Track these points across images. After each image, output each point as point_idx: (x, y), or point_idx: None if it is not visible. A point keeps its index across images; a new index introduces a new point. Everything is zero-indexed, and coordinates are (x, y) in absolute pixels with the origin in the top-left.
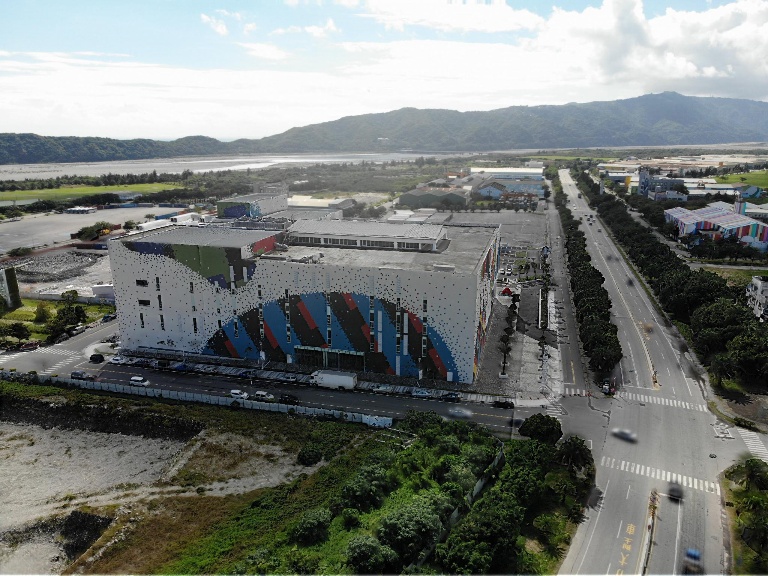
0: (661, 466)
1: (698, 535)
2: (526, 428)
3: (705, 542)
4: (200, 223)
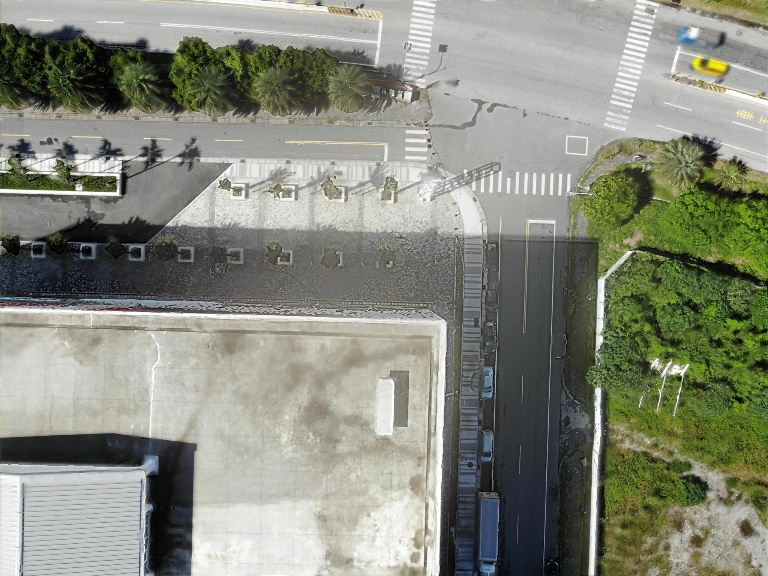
0: (614, 58)
1: (740, 49)
2: None
3: (749, 45)
4: None
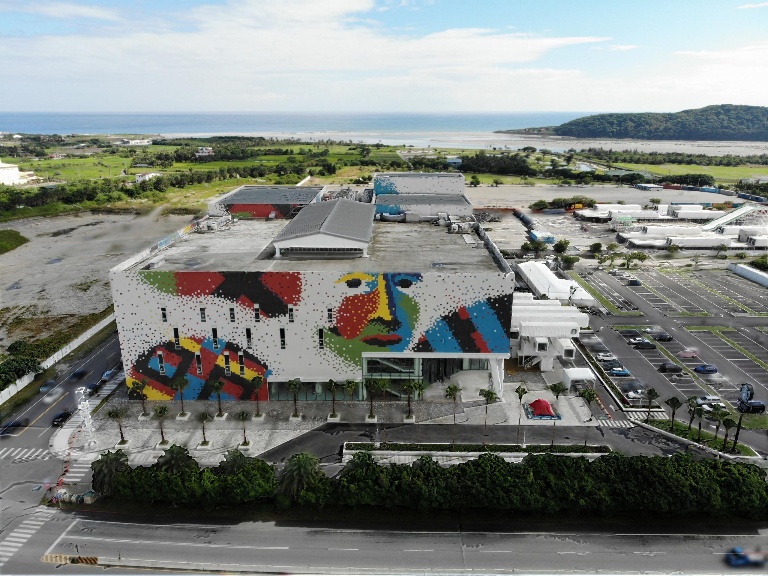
0: None
1: None
2: None
3: None
4: (665, 216)
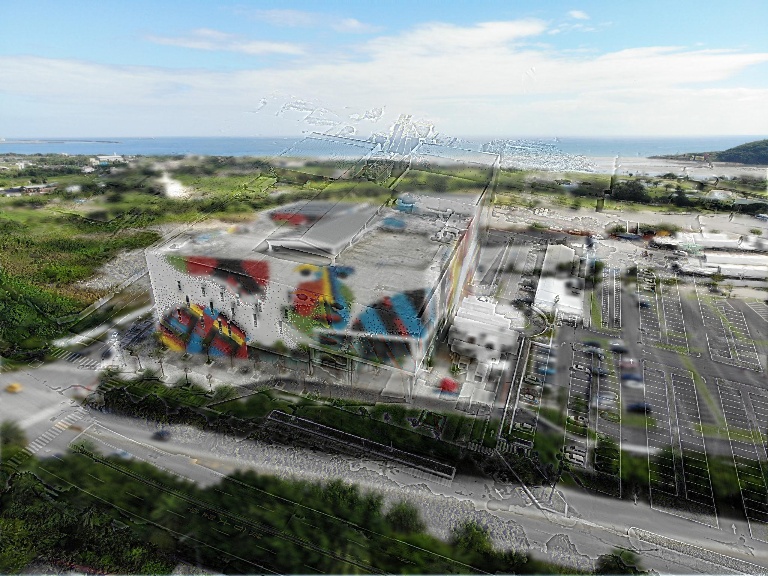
0: None
1: None
2: None
3: None
4: None
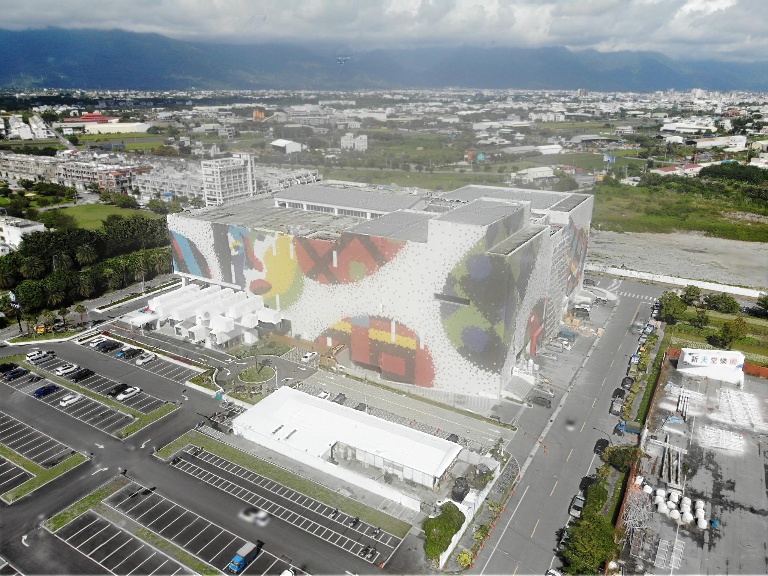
0: None
1: None
2: None
3: None
4: None
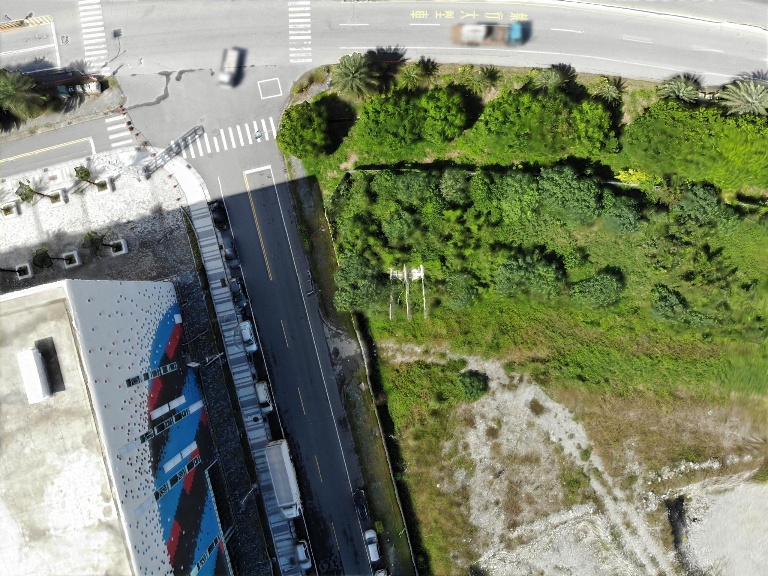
0: None
1: None
2: (316, 148)
3: None
4: None
